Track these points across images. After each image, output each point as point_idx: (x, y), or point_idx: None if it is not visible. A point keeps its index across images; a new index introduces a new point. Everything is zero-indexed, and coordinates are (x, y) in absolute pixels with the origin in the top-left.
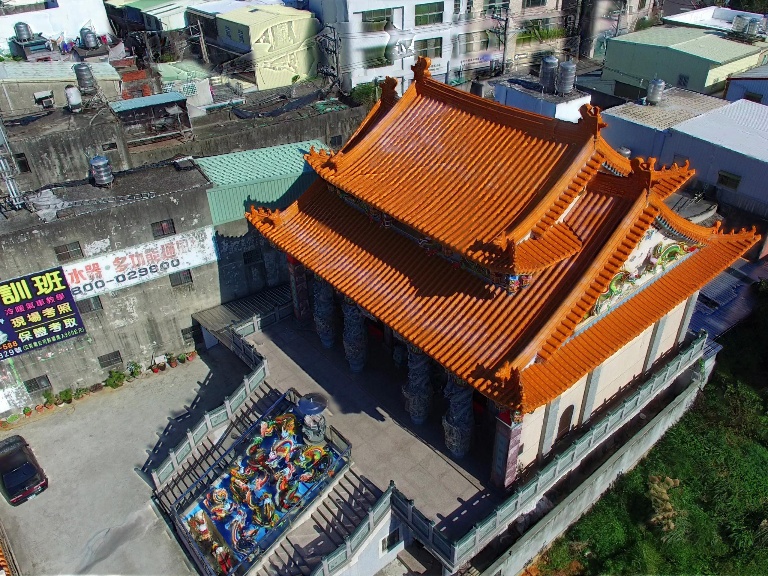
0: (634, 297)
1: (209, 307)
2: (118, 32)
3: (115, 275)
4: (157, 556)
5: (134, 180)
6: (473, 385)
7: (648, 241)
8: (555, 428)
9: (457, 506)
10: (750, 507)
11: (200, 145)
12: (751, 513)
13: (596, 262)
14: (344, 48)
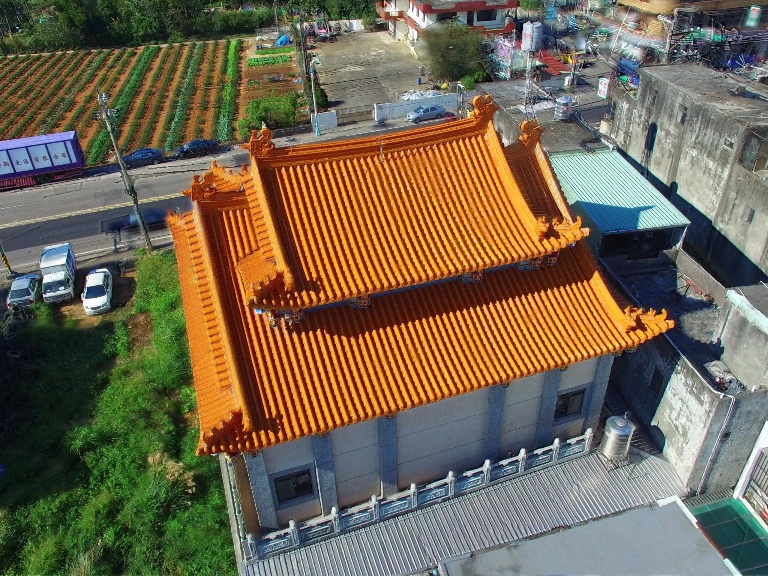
0: None
1: None
2: None
3: None
4: None
5: (568, 128)
6: None
7: None
8: None
9: None
10: (127, 573)
11: None
12: (123, 569)
13: None
14: None
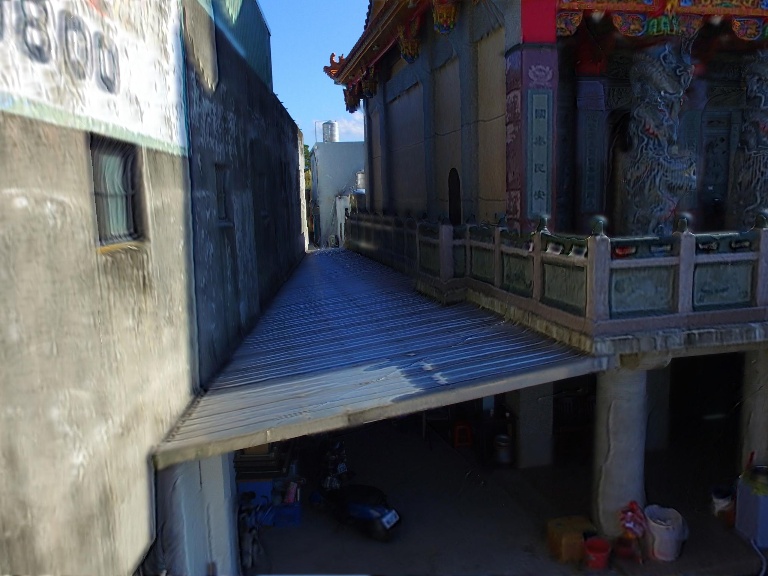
0: None
1: (181, 407)
2: None
3: None
4: None
5: None
6: None
7: None
8: None
9: None
10: None
11: None
12: None
13: None
14: None
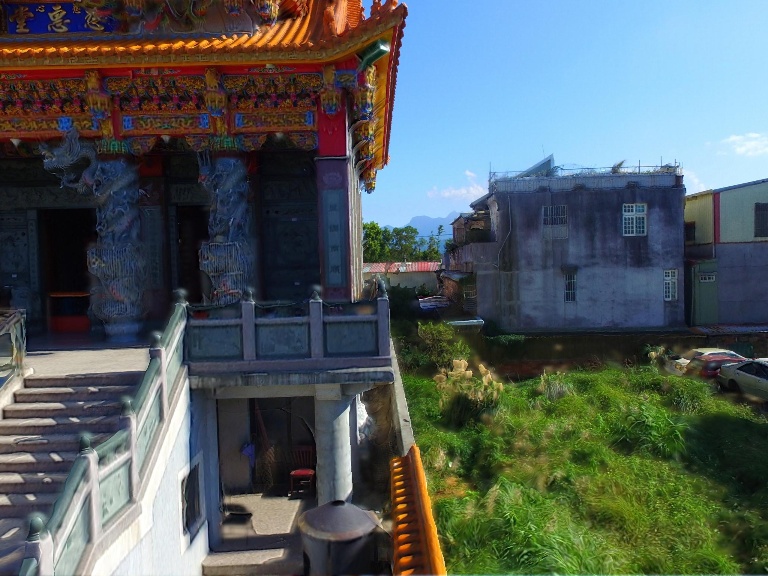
0: None
1: None
2: None
3: None
4: None
5: None
6: (293, 44)
7: None
8: None
9: None
10: None
11: None
12: None
13: (340, 0)
14: None
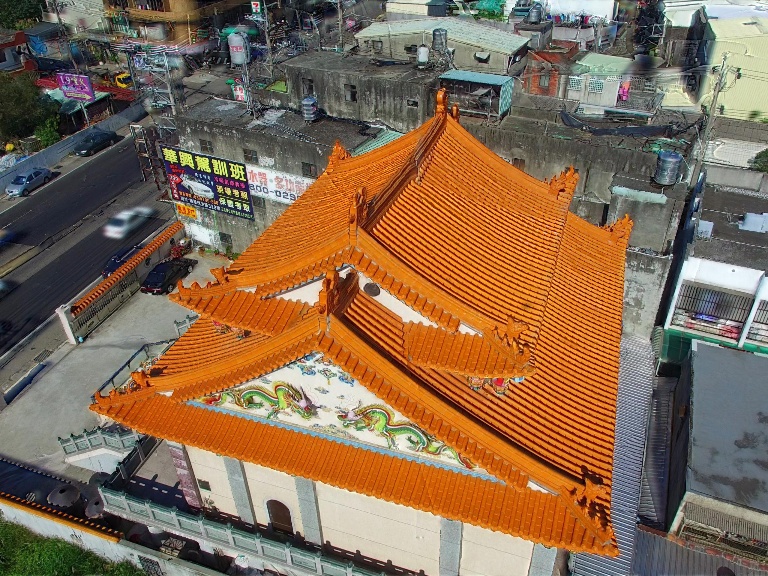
0: (347, 445)
1: None
2: (621, 16)
3: (276, 189)
4: (132, 369)
5: (328, 126)
6: None
7: (350, 386)
8: (262, 508)
9: (170, 484)
10: None
11: (486, 131)
12: None
13: (248, 350)
14: (741, 88)
